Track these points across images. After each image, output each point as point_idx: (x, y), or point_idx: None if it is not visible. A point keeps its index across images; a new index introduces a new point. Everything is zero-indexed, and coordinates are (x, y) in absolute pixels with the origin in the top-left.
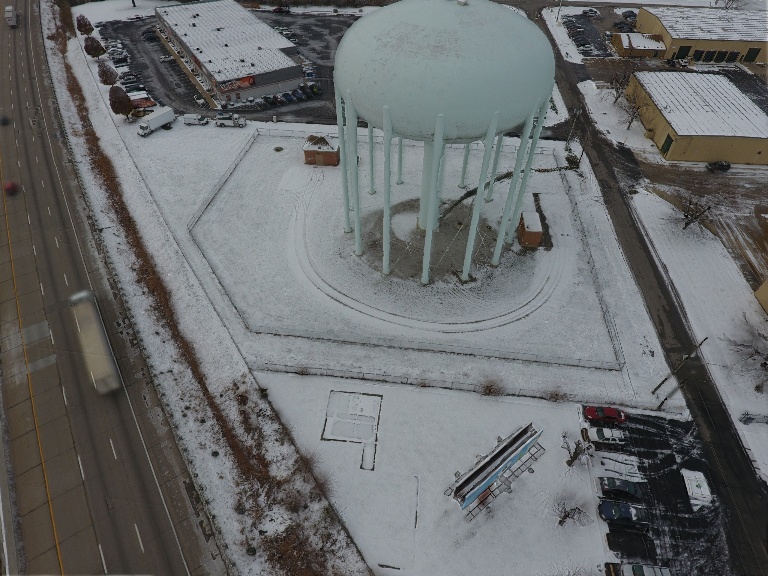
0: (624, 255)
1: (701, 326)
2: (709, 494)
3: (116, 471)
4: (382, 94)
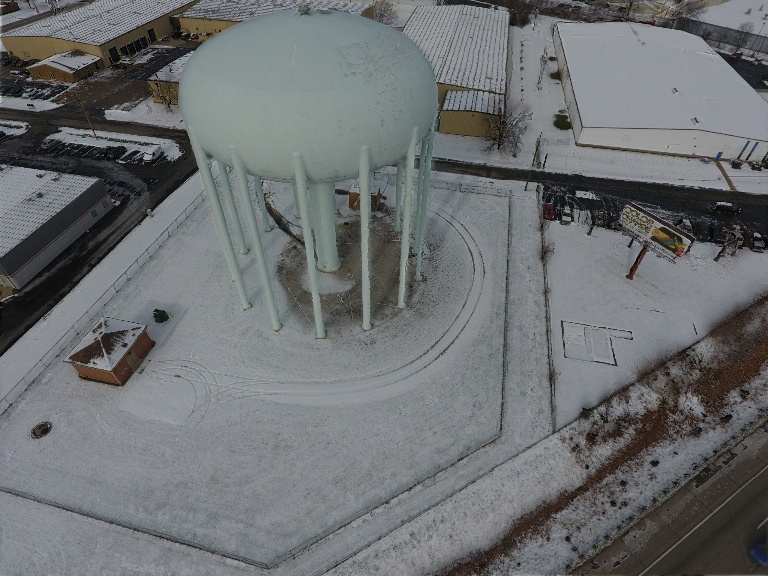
0: (394, 167)
1: (467, 158)
2: (588, 192)
3: (719, 571)
4: (411, 117)
